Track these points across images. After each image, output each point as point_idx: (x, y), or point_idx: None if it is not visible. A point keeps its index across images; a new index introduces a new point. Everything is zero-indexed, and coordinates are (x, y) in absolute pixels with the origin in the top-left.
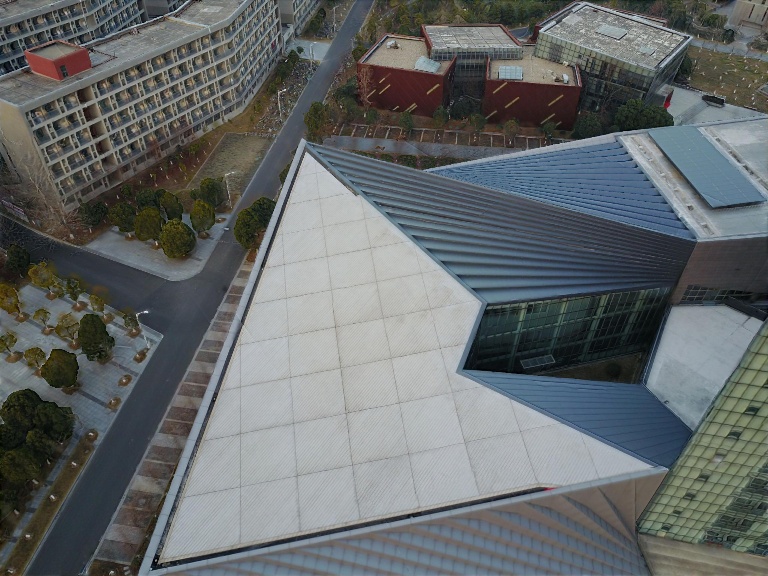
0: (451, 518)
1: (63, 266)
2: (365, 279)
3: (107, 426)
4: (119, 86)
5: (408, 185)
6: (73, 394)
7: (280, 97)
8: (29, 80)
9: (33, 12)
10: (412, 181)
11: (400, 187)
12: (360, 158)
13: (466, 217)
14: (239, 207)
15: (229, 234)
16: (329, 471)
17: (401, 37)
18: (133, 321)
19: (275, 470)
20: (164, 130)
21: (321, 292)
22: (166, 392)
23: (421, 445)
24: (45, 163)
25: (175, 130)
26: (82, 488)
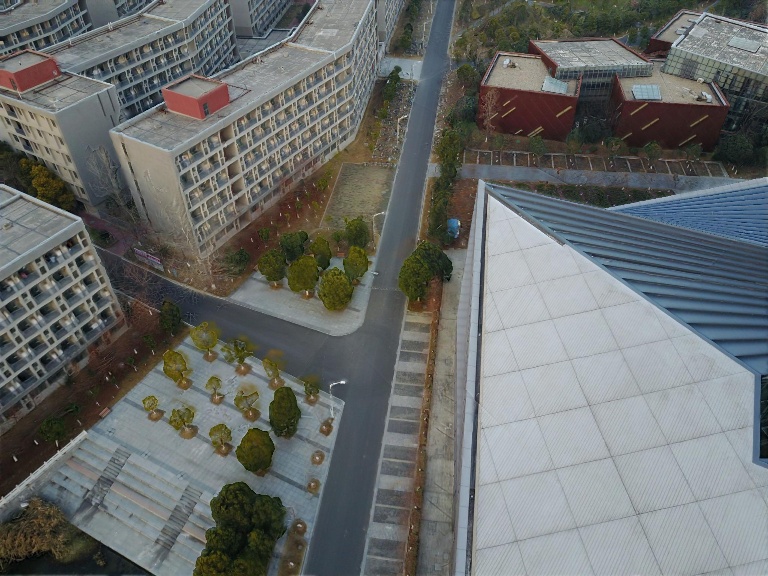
0: None
1: (213, 321)
2: (605, 346)
3: (313, 515)
4: (255, 122)
5: (617, 232)
6: (265, 476)
7: (389, 122)
8: (167, 119)
9: (140, 41)
10: (621, 227)
11: (608, 234)
12: (552, 201)
13: (695, 269)
14: (382, 248)
15: (380, 279)
16: None
17: (514, 55)
18: (315, 388)
19: None
20: (289, 164)
21: (558, 362)
22: (367, 471)
23: (741, 556)
24: (188, 209)
25: (298, 163)
26: None
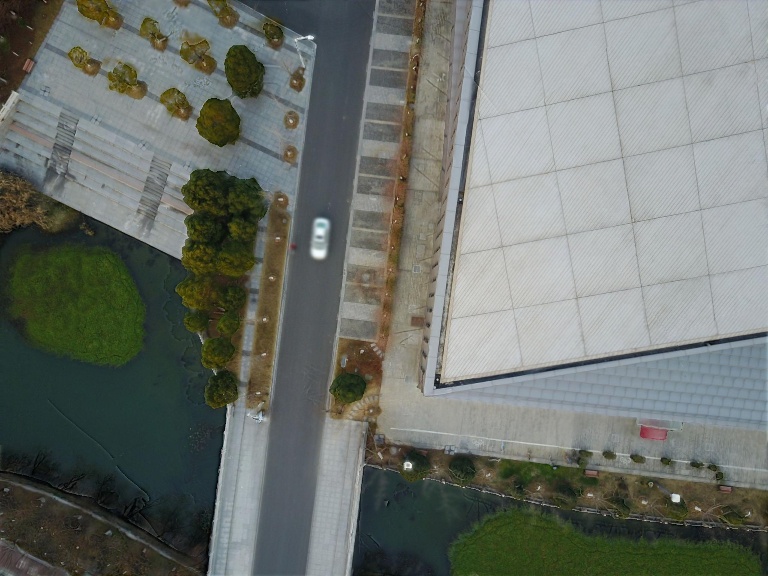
0: (751, 345)
1: None
2: (655, 1)
3: (294, 186)
4: None
5: None
6: (236, 144)
7: None
8: None
9: None
10: None
11: None
12: None
13: None
14: None
15: None
16: (614, 293)
17: None
18: (277, 32)
19: (551, 291)
20: None
21: (588, 27)
22: (348, 136)
23: (725, 265)
24: None
25: None
26: (297, 264)
